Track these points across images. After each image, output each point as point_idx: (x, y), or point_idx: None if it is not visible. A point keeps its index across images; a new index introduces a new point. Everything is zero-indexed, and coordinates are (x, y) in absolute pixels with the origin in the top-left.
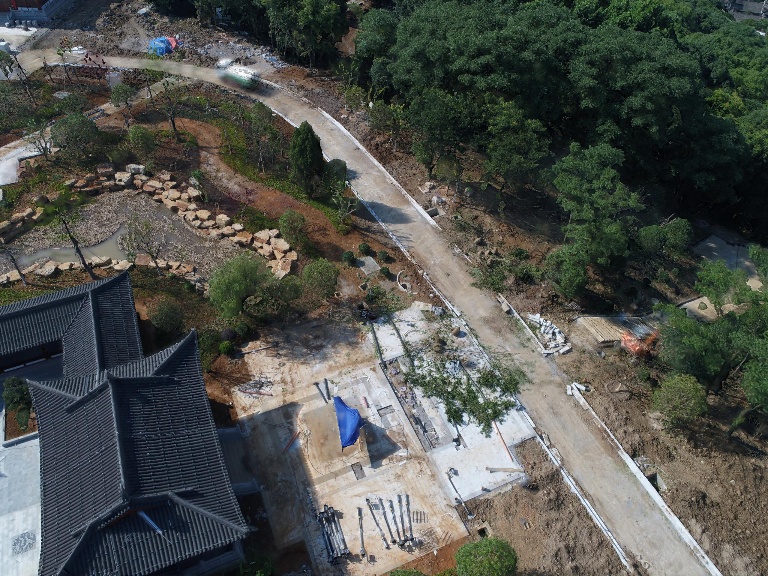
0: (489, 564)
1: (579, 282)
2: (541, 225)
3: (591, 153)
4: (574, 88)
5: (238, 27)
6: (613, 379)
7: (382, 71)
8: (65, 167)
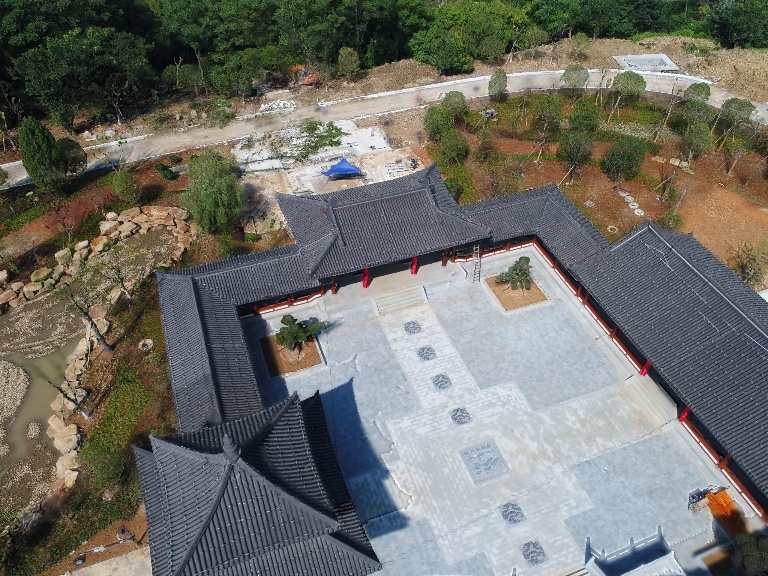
0: (442, 110)
1: None
2: (157, 105)
3: (188, 0)
4: None
5: None
6: (318, 92)
7: None
8: None
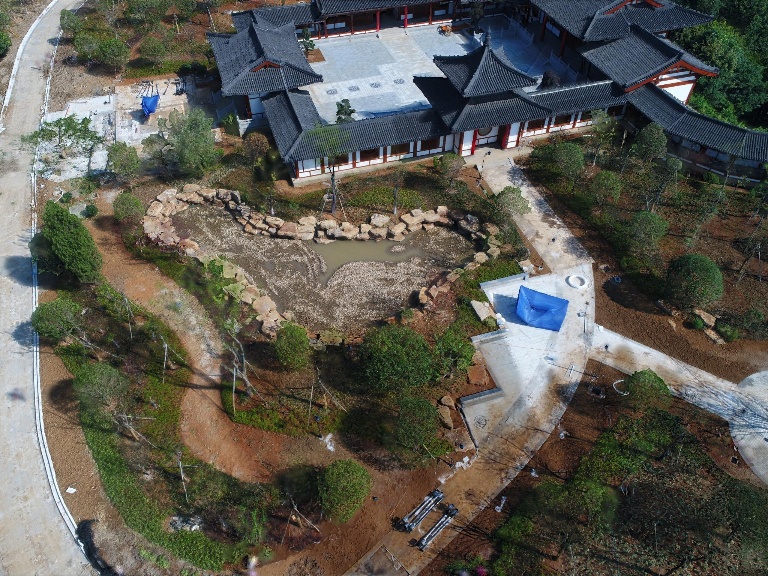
0: None
1: None
2: None
3: None
4: None
5: None
6: None
7: None
8: None
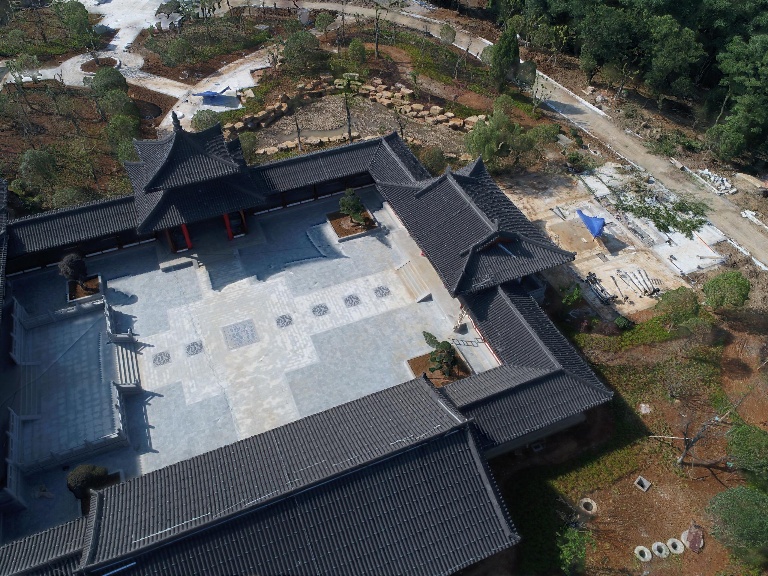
0: (737, 281)
1: (740, 143)
2: (683, 121)
3: (754, 41)
4: (709, 11)
5: None
6: None
7: (538, 3)
8: (292, 76)
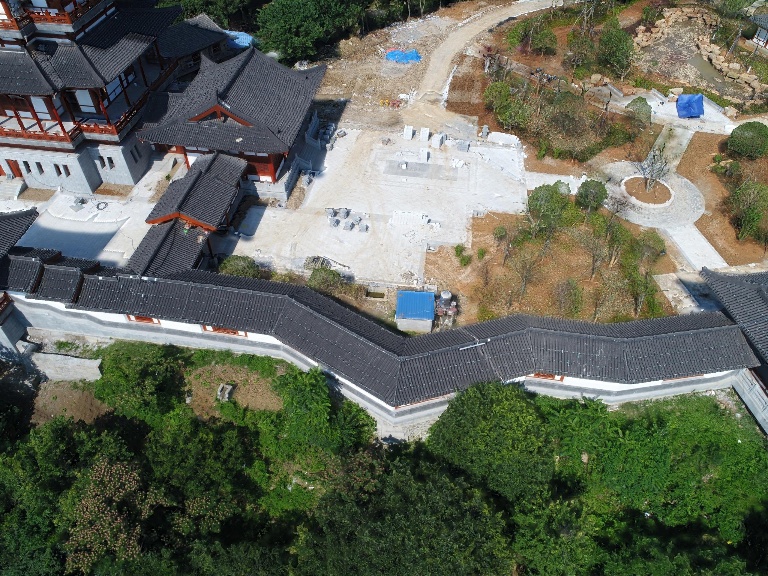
0: None
1: None
2: None
3: None
4: None
5: (321, 45)
6: None
7: None
8: (627, 74)
